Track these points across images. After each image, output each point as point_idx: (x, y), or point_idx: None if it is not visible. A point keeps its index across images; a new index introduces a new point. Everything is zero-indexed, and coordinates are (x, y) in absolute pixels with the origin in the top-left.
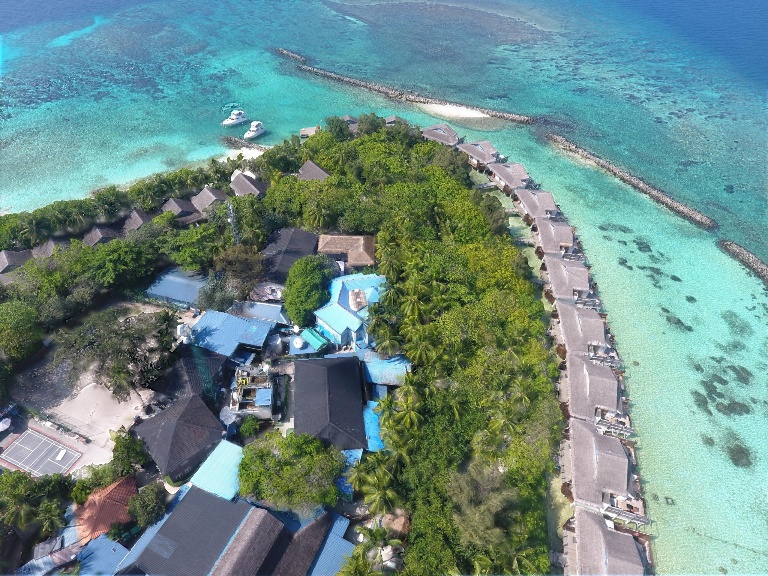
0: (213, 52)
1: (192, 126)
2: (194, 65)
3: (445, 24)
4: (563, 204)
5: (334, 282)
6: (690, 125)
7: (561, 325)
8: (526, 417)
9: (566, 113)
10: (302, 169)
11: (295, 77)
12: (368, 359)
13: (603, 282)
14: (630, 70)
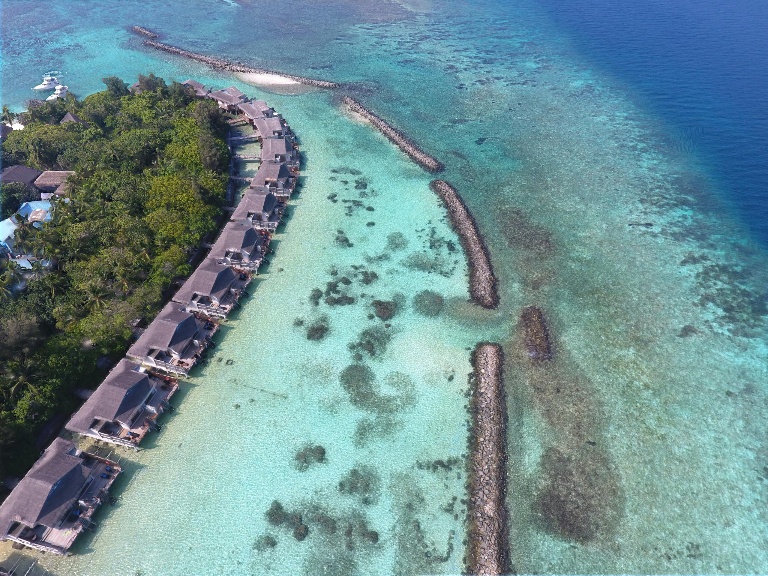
0: (70, 30)
1: (7, 91)
2: (43, 41)
3: (318, 6)
4: (313, 153)
5: (23, 204)
6: (487, 90)
7: (218, 238)
8: (121, 298)
9: (376, 81)
10: (62, 120)
11: (136, 51)
12: (17, 260)
13: (301, 211)
14: (469, 45)
